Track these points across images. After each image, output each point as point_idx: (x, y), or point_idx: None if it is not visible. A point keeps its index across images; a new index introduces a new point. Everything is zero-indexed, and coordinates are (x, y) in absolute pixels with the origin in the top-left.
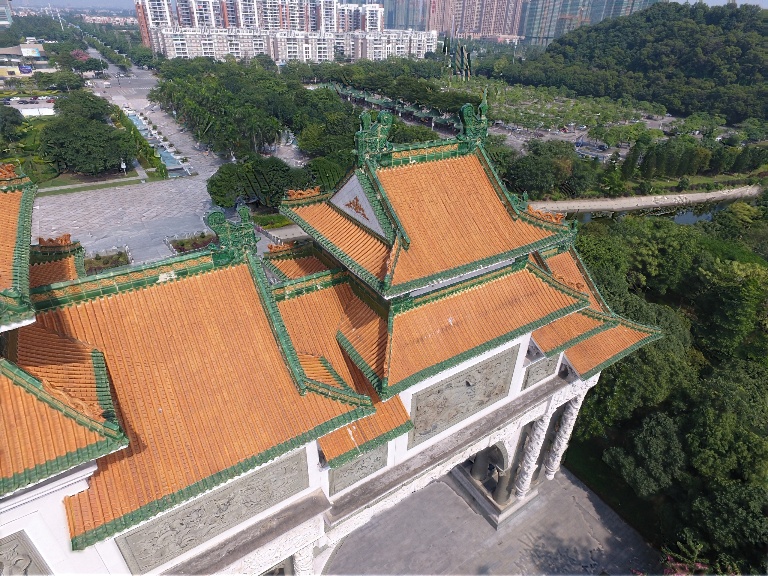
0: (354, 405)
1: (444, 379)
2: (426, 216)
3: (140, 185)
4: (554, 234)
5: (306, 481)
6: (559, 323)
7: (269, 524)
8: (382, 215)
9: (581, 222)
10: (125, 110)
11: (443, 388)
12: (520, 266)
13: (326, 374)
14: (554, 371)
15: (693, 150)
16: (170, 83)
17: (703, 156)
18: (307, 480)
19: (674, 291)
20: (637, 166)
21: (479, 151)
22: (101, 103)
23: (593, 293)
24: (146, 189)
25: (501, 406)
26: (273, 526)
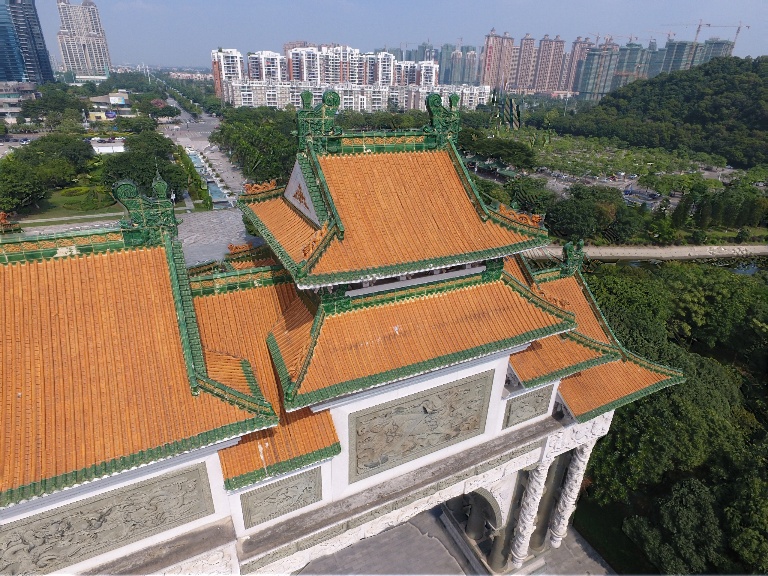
0: (253, 413)
1: (392, 400)
2: (374, 208)
3: (185, 215)
4: (531, 239)
5: (210, 505)
6: (546, 350)
7: (158, 552)
8: (319, 202)
9: (620, 266)
10: (187, 150)
11: (391, 411)
12: (493, 276)
13: (240, 378)
14: (546, 410)
15: (754, 200)
16: (229, 126)
17: (766, 207)
18: (211, 504)
19: (725, 344)
20: (690, 214)
21: (450, 146)
22: (166, 142)
23: (601, 324)
24: (190, 218)
25: (476, 445)
26: (161, 555)
